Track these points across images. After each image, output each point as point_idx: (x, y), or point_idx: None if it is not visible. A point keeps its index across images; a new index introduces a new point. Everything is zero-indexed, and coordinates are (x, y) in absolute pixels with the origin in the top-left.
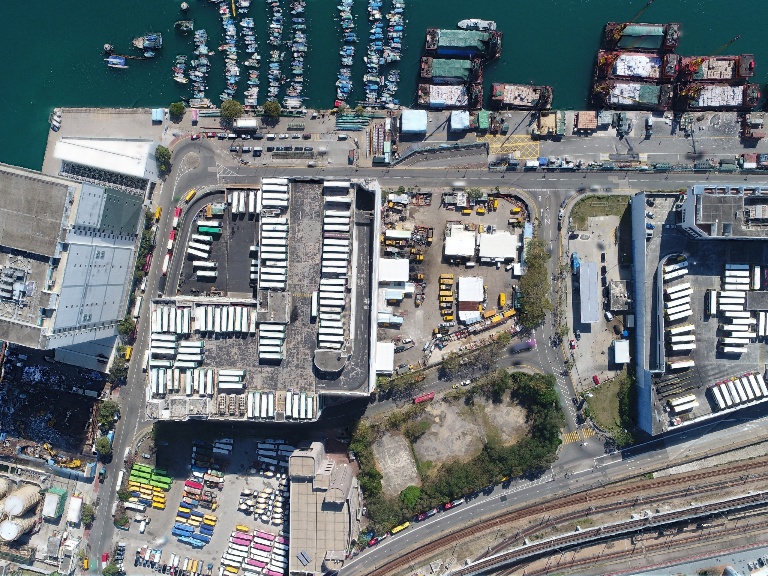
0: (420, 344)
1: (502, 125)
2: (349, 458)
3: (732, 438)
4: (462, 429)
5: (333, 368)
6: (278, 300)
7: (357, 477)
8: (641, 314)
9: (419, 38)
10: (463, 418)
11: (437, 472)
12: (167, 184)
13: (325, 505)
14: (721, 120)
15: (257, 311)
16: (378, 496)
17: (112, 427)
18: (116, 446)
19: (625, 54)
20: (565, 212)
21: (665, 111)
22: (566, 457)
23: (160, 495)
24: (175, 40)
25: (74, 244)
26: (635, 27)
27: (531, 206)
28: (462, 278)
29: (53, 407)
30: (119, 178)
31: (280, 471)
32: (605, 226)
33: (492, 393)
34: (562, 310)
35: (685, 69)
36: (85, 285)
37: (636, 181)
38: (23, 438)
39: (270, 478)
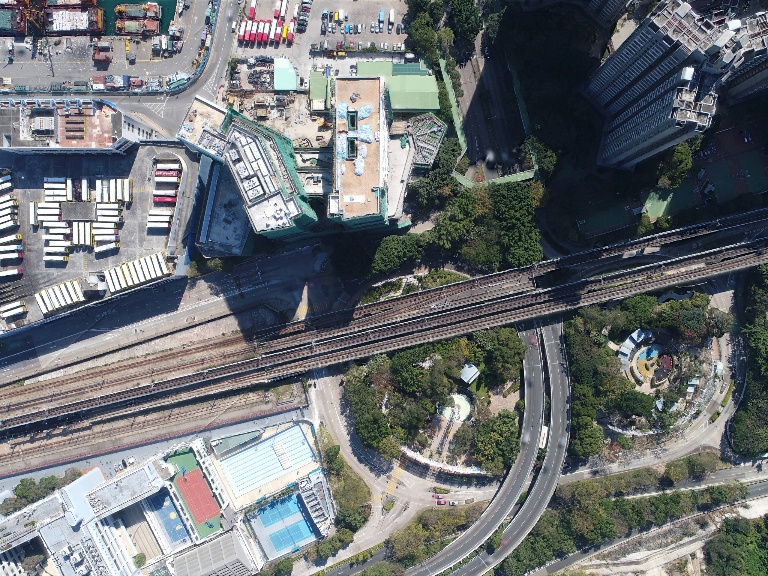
0: None
1: None
2: None
3: (96, 347)
4: None
5: None
6: None
7: None
8: None
9: None
10: None
11: None
12: None
13: None
14: (76, 44)
15: None
16: None
17: None
18: None
19: None
20: None
21: (26, 36)
22: None
23: None
24: None
25: None
26: None
27: None
28: None
29: None
30: None
31: None
32: None
33: None
34: None
35: None
36: None
37: None
38: None
39: None
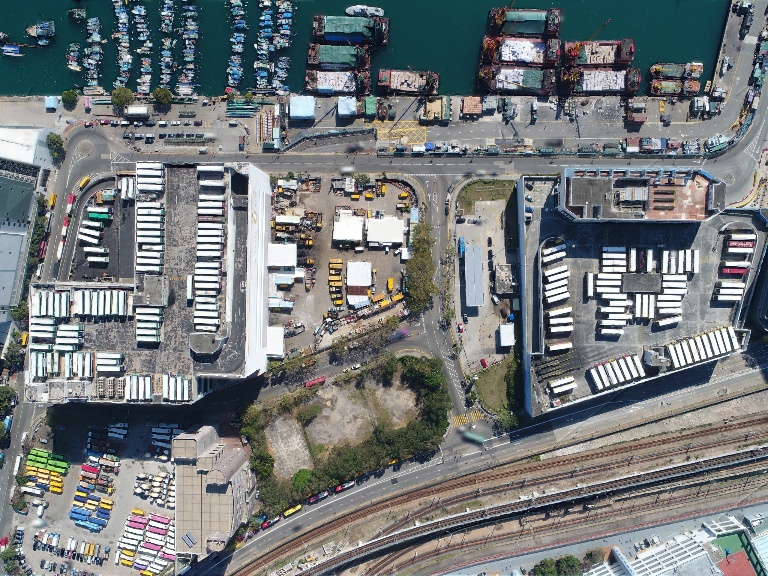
0: (311, 328)
1: (390, 111)
2: (242, 442)
3: (618, 420)
4: (353, 413)
5: (208, 350)
6: (154, 284)
7: (250, 461)
8: (524, 297)
9: (308, 25)
10: (354, 402)
11: (329, 455)
12: (61, 171)
13: (210, 487)
14: (605, 105)
15: (134, 295)
16: (269, 479)
17: (10, 412)
18: (14, 431)
19: (510, 39)
20: (452, 197)
21: (550, 96)
22: (455, 440)
23: (57, 479)
24: (69, 28)
25: None
26: (519, 12)
27: (419, 191)
28: (350, 263)
29: None
30: (11, 165)
31: None
32: (491, 210)
33: (382, 377)
34: (450, 294)
35: (568, 54)
36: None
37: (521, 166)
38: None
39: (165, 462)
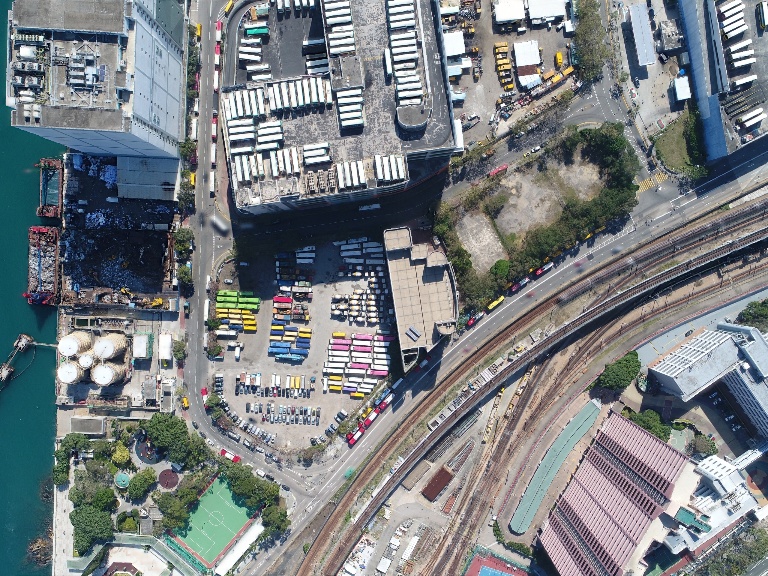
0: (485, 119)
1: None
2: (433, 245)
3: None
4: (539, 196)
5: (418, 122)
6: (351, 64)
7: None
8: (696, 45)
9: None
10: (539, 185)
11: (522, 243)
12: None
13: (425, 277)
14: None
15: (331, 79)
16: (470, 273)
17: (188, 259)
18: (196, 277)
19: None
20: None
21: None
22: (644, 205)
23: (250, 317)
24: None
25: (139, 23)
26: None
27: None
28: (516, 43)
29: (124, 249)
30: None
31: (368, 270)
32: None
33: (563, 155)
34: (618, 61)
35: None
36: (151, 79)
37: None
38: (98, 286)
39: (358, 280)
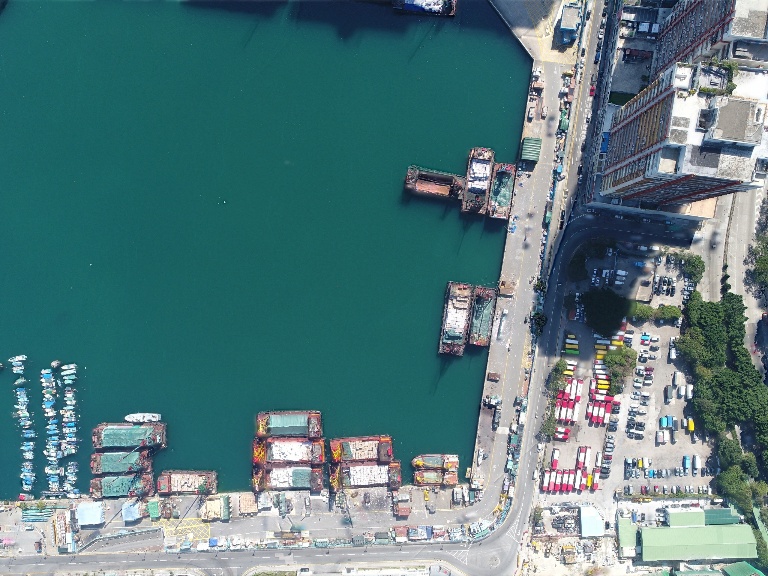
0: None
1: (173, 510)
2: None
3: None
4: None
5: None
6: None
7: None
8: None
9: None
10: None
11: None
12: None
13: None
14: (373, 495)
15: None
16: None
17: None
18: None
19: (279, 440)
20: None
21: (322, 489)
22: None
23: None
24: None
25: None
26: (284, 416)
27: None
28: None
29: None
30: None
31: None
32: None
33: None
34: None
35: (332, 455)
36: None
37: (300, 557)
38: None
39: None
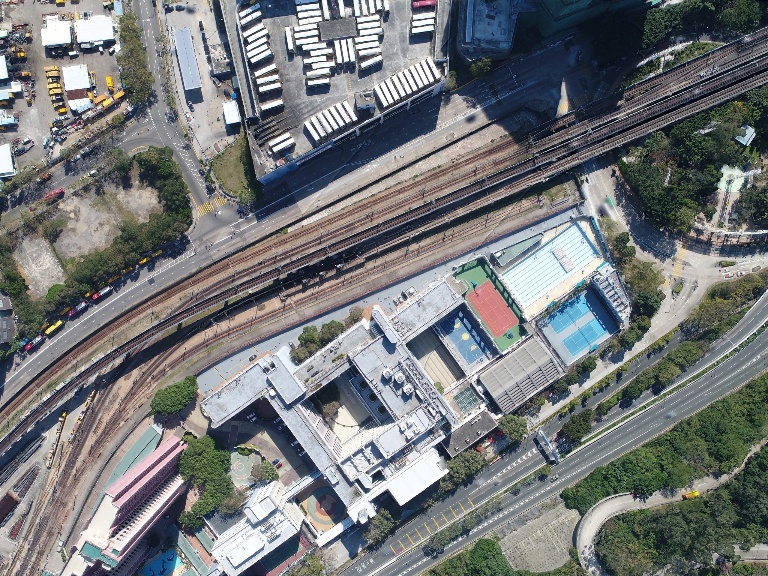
0: (40, 143)
1: None
2: None
3: (357, 181)
4: (98, 220)
5: None
6: None
7: None
8: None
9: None
10: (97, 209)
11: None
12: None
13: None
14: None
15: None
16: (20, 297)
17: None
18: None
19: None
20: None
21: None
22: (203, 229)
23: None
24: None
25: None
26: None
27: None
28: (65, 67)
29: None
30: None
31: None
32: None
33: (121, 179)
34: (172, 84)
35: None
36: None
37: None
38: None
39: None
